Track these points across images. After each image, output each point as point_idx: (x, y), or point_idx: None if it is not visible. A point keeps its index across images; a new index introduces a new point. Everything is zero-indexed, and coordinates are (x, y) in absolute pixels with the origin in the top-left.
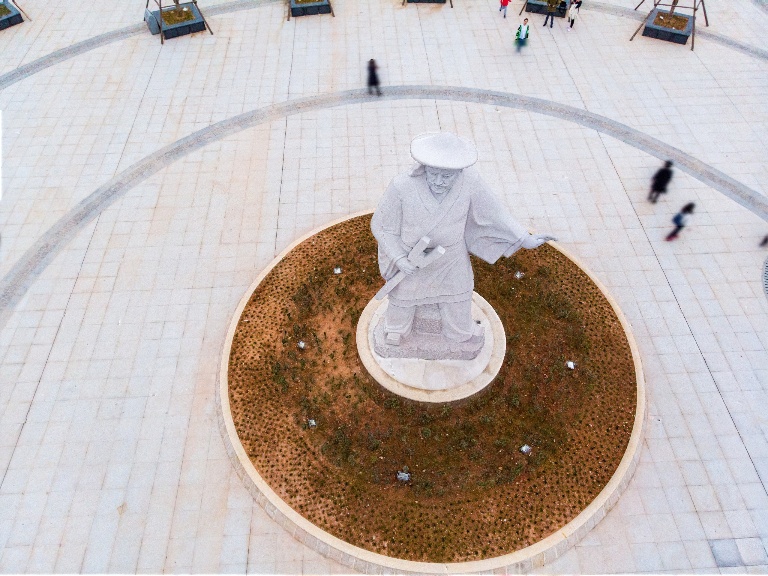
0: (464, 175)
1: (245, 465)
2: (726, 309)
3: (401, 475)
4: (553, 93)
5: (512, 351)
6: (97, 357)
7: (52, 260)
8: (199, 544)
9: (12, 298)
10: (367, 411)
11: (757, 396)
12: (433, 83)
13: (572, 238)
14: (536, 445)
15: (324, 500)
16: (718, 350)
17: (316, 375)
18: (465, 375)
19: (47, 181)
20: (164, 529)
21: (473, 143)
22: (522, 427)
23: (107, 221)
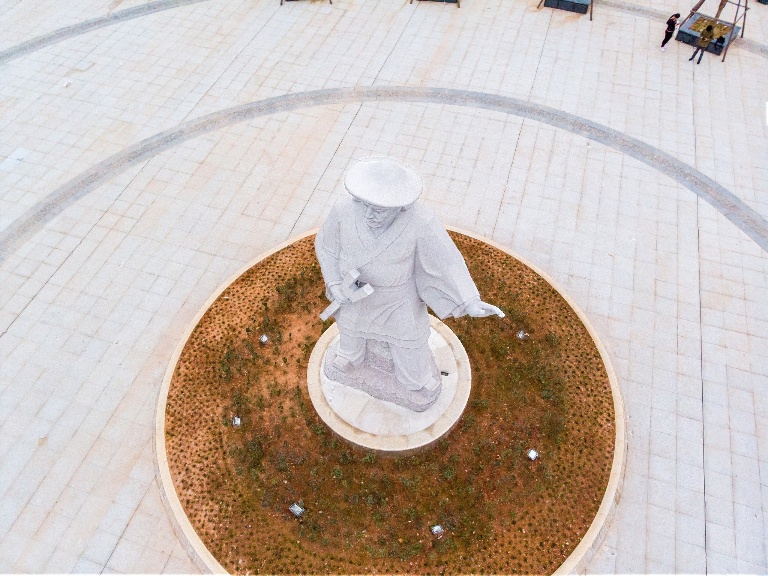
0: (413, 214)
1: (158, 440)
2: (763, 452)
3: (295, 507)
4: (663, 139)
5: (471, 417)
6: (88, 291)
7: (94, 189)
8: (89, 501)
9: (47, 215)
10: (294, 428)
11: (753, 571)
12: (530, 99)
13: (608, 310)
14: (451, 530)
15: (212, 504)
16: (728, 498)
17: (264, 374)
18: (404, 426)
19: (124, 114)
20: (67, 474)
21: (544, 175)
22: (445, 504)
23: (155, 165)
